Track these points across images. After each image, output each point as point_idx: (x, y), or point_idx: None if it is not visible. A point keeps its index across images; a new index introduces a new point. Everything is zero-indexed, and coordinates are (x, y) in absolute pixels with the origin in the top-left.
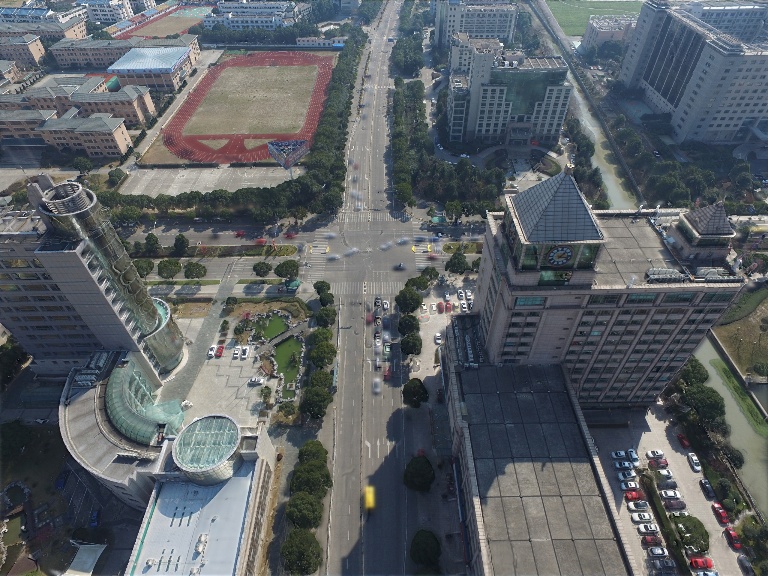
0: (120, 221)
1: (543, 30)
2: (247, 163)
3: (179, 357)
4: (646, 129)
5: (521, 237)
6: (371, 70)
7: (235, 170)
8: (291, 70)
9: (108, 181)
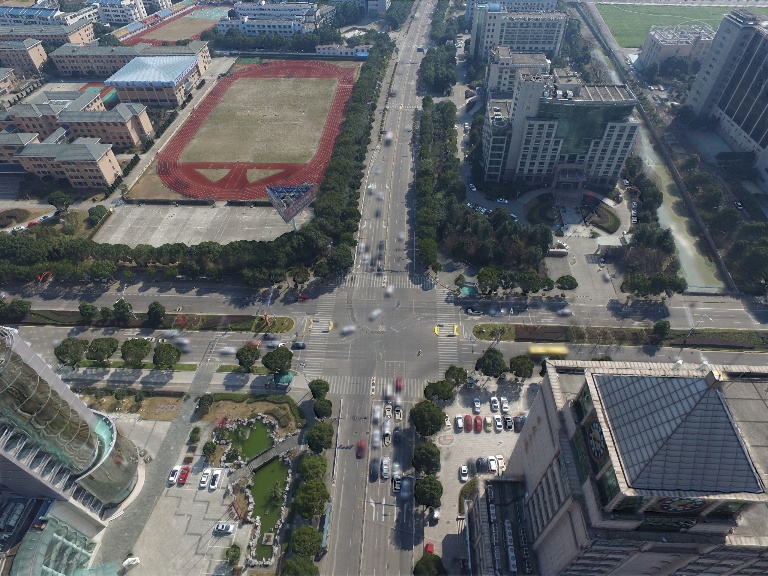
0: (91, 276)
1: (593, 39)
2: (247, 202)
3: (131, 484)
4: (724, 171)
5: (620, 478)
6: (397, 85)
7: (232, 210)
8: (308, 83)
9: (88, 219)
